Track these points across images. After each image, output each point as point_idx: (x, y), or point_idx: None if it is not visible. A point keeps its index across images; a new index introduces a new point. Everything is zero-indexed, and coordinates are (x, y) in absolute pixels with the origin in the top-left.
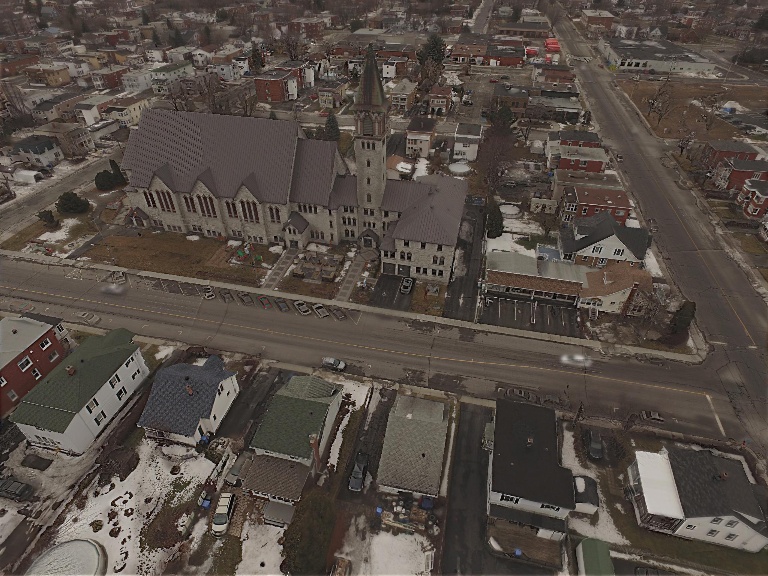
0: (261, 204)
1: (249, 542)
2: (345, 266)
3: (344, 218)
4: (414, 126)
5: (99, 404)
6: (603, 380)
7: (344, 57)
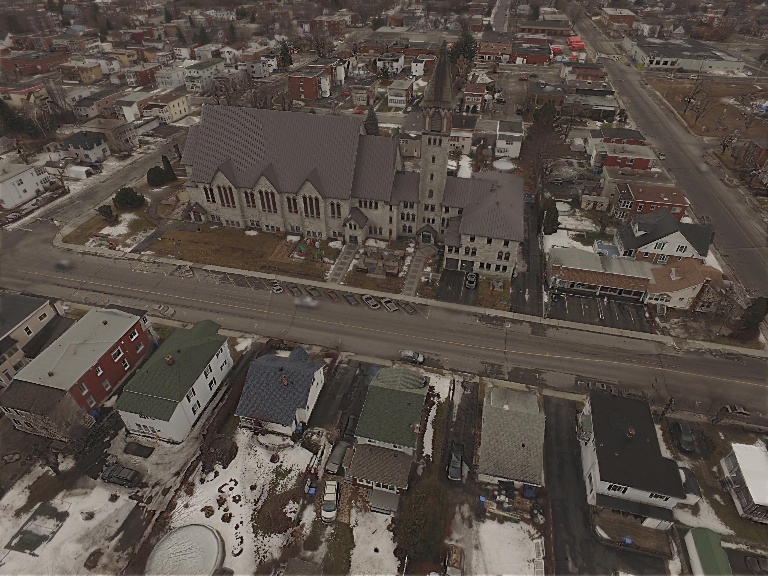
0: (323, 199)
1: (359, 529)
2: (406, 261)
3: (403, 214)
4: (455, 123)
5: (196, 394)
6: (681, 374)
7: (369, 55)
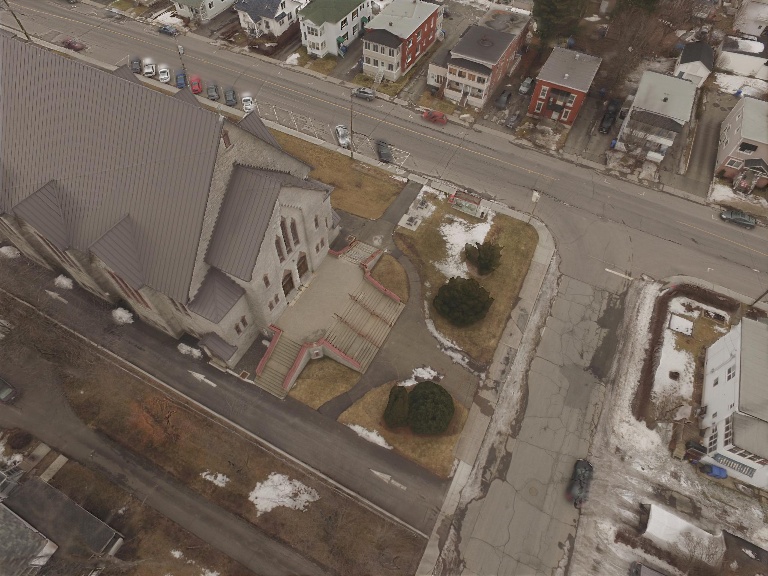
0: None
1: None
2: None
3: None
4: None
5: None
6: None
7: None
